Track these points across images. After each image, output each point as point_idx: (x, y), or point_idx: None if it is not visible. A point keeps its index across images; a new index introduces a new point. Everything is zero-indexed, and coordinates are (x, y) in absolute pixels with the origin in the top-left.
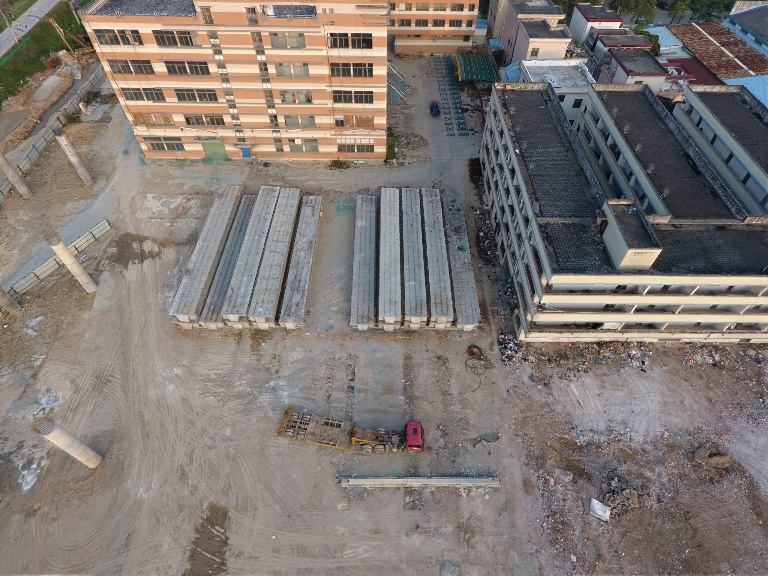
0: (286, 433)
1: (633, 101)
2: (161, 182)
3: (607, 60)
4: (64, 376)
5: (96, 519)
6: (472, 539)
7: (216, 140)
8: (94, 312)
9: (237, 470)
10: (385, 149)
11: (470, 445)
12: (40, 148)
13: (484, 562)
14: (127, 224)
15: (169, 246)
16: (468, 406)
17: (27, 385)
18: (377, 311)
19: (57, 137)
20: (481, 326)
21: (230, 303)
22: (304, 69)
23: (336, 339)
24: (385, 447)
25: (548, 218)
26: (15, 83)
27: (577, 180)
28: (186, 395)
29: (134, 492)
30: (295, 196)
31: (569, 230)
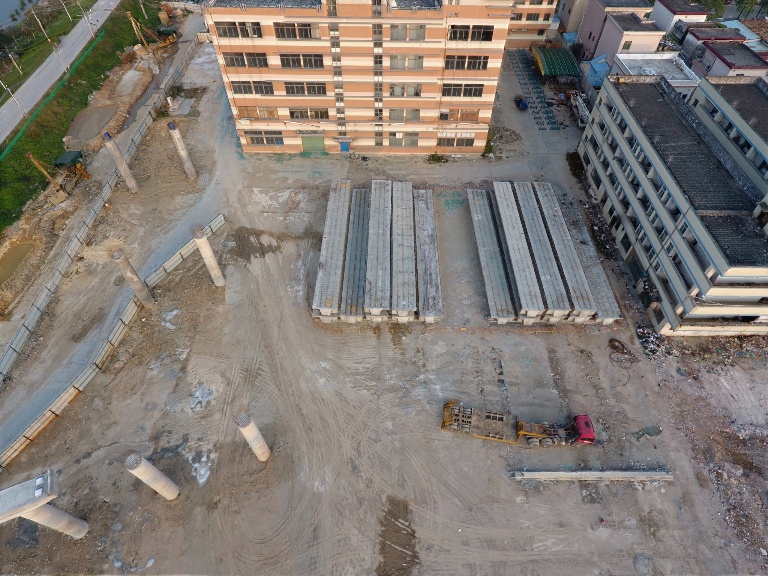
0: (451, 426)
1: (749, 94)
2: (264, 176)
3: (698, 53)
4: (213, 369)
5: (278, 512)
6: (658, 533)
7: (319, 134)
8: (228, 306)
9: (408, 463)
10: (485, 143)
11: (634, 439)
12: (137, 142)
13: (675, 555)
14: (240, 218)
15: (287, 240)
16: (622, 400)
17: (178, 378)
18: (515, 305)
19: (171, 130)
20: (617, 320)
21: (371, 296)
22: (418, 62)
23: (476, 333)
24: (553, 440)
25: (703, 211)
26: (97, 77)
27: (719, 173)
28: (339, 388)
29: (310, 485)
30: (409, 190)
31: (727, 223)
